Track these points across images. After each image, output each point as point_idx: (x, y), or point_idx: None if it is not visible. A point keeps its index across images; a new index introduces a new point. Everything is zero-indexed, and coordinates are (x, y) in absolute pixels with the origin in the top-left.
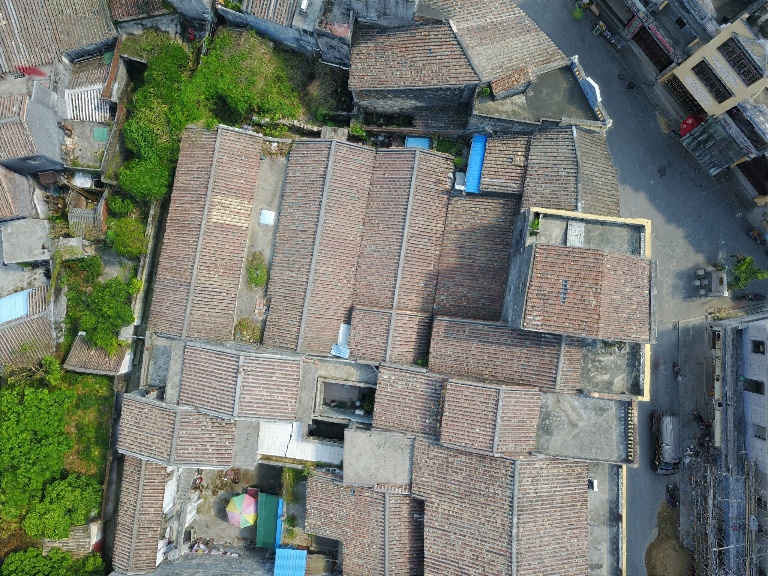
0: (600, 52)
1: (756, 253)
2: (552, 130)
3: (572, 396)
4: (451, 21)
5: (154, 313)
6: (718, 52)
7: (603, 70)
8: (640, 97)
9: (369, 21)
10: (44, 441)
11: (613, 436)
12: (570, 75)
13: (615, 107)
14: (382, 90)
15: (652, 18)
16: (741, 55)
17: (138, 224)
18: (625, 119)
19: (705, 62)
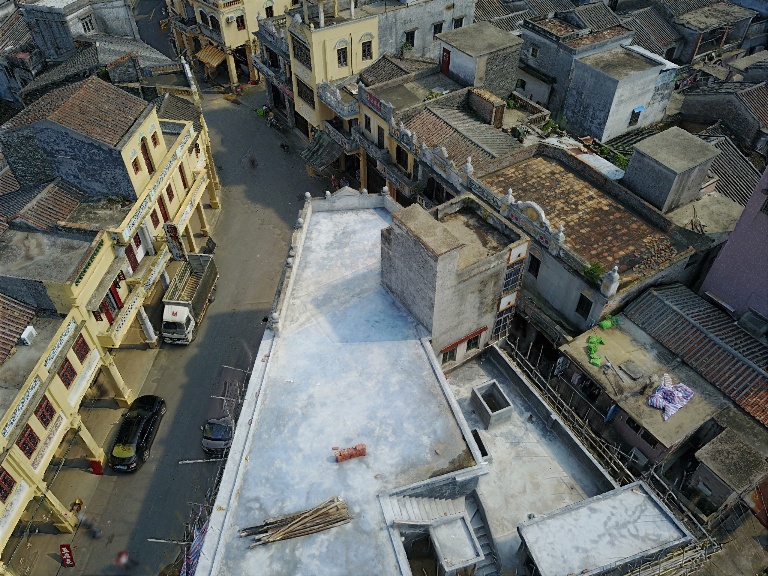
0: (270, 135)
1: None
2: (154, 100)
3: (44, 235)
4: (98, 42)
5: None
6: (295, 59)
7: (269, 143)
8: (295, 157)
9: (53, 60)
10: None
11: (69, 271)
12: (183, 76)
13: (271, 161)
14: (38, 90)
15: (279, 78)
16: (300, 46)
17: None
18: (278, 167)
19: (298, 79)
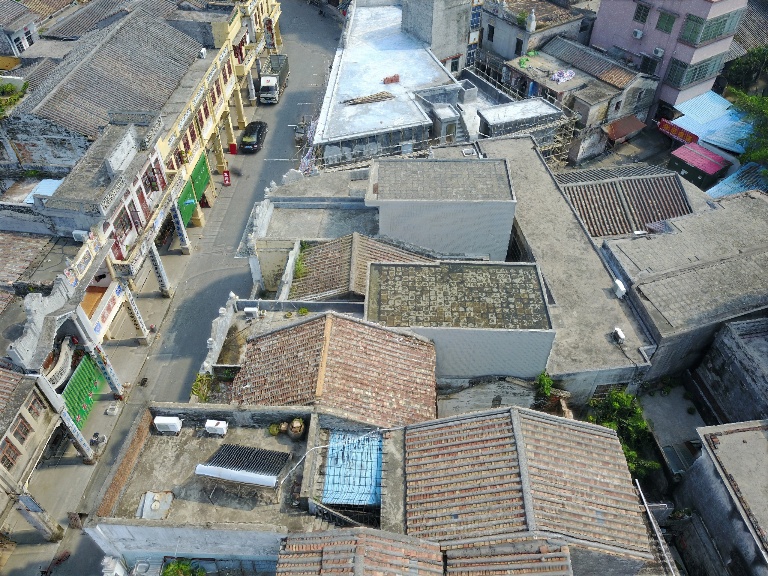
0: None
1: None
2: None
3: (200, 12)
4: None
5: None
6: None
7: None
8: None
9: None
10: None
11: None
12: None
13: None
14: None
15: None
16: None
17: None
18: (318, 25)
19: None
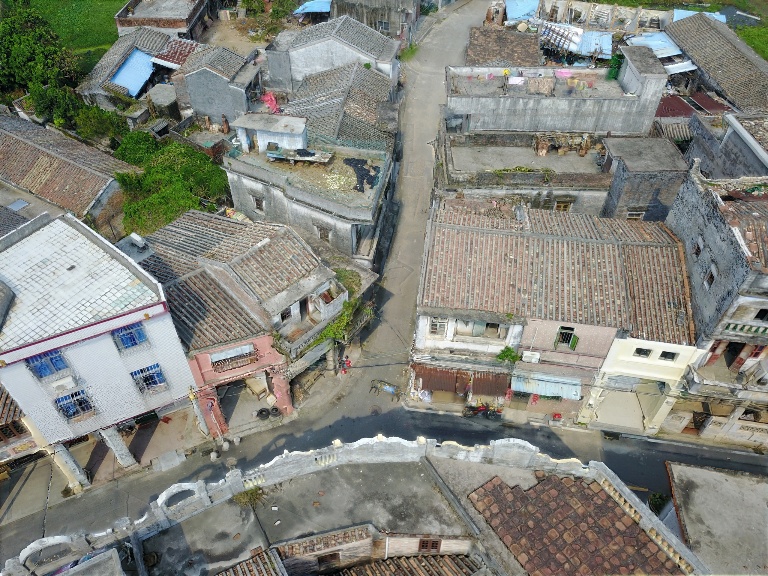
0: None
1: None
2: None
3: None
4: None
5: (22, 120)
6: None
7: None
8: None
9: None
10: (5, 56)
11: None
12: None
13: None
14: None
15: None
16: None
17: (96, 128)
18: None
19: None
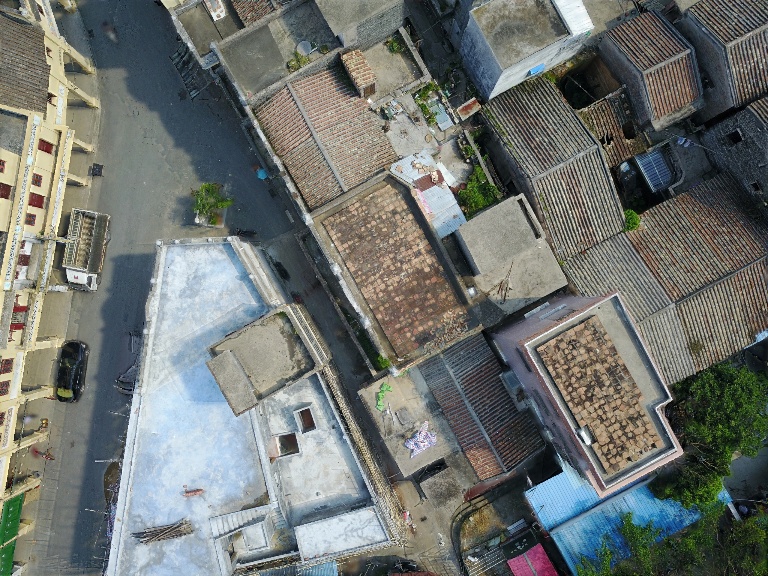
0: None
1: (261, 191)
2: None
3: None
4: None
5: None
6: None
7: None
8: None
9: None
10: None
11: None
12: None
13: (147, 23)
14: None
15: None
16: None
17: None
18: (155, 37)
19: None
